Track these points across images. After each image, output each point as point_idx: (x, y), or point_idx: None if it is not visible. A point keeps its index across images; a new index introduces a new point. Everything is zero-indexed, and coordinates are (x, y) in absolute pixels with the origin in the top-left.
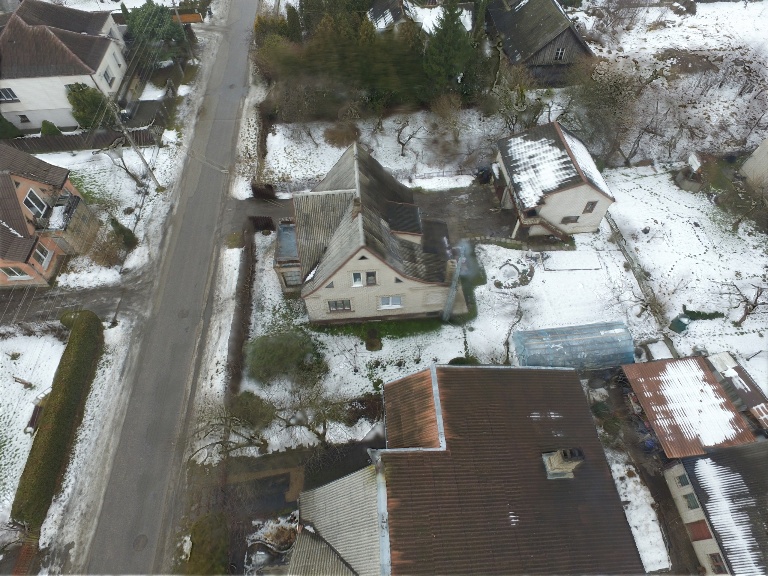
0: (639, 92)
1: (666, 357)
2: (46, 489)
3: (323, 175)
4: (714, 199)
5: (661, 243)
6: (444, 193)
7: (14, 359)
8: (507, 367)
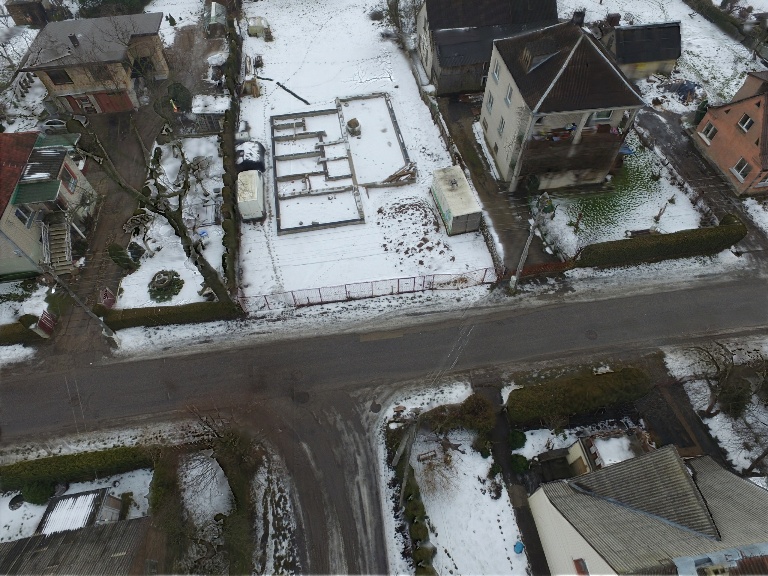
0: None
1: None
2: (605, 260)
3: None
4: None
5: None
6: None
7: (669, 202)
8: None
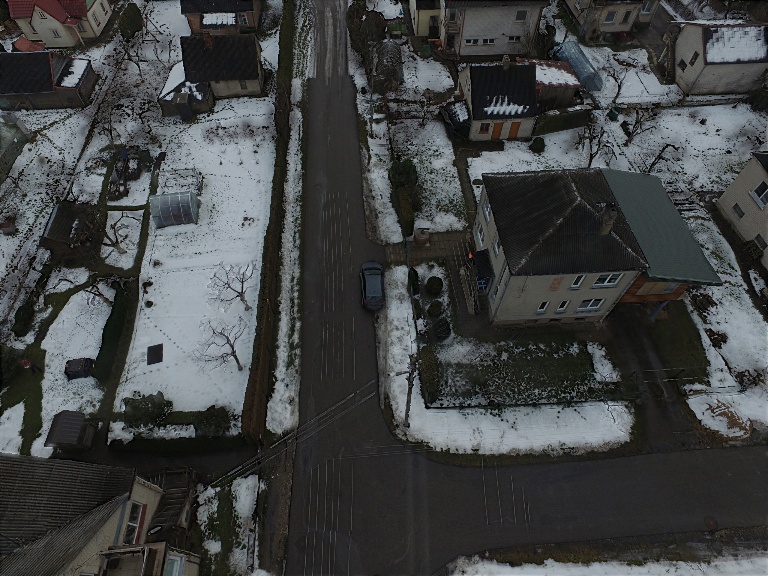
0: None
1: None
2: None
3: None
4: None
5: (691, 121)
6: None
7: None
8: None
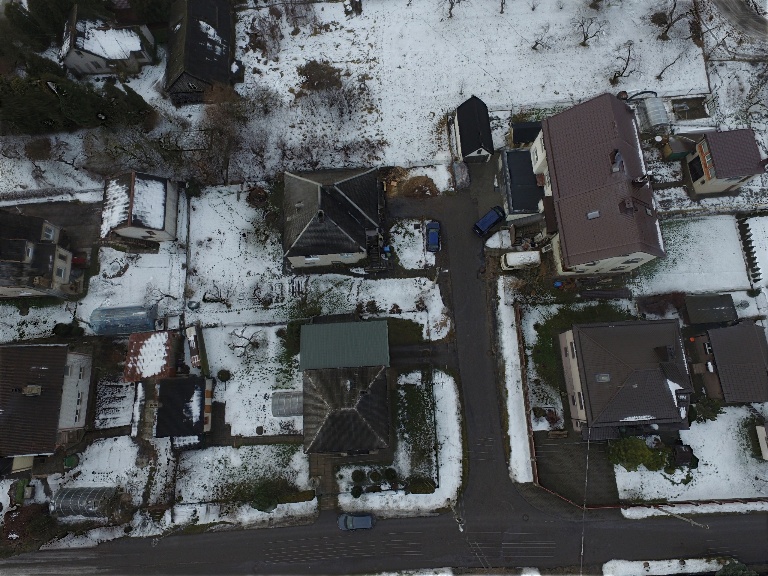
0: (266, 111)
1: (176, 325)
2: None
3: (19, 186)
4: (266, 215)
5: (210, 250)
6: (93, 205)
7: None
8: (27, 346)
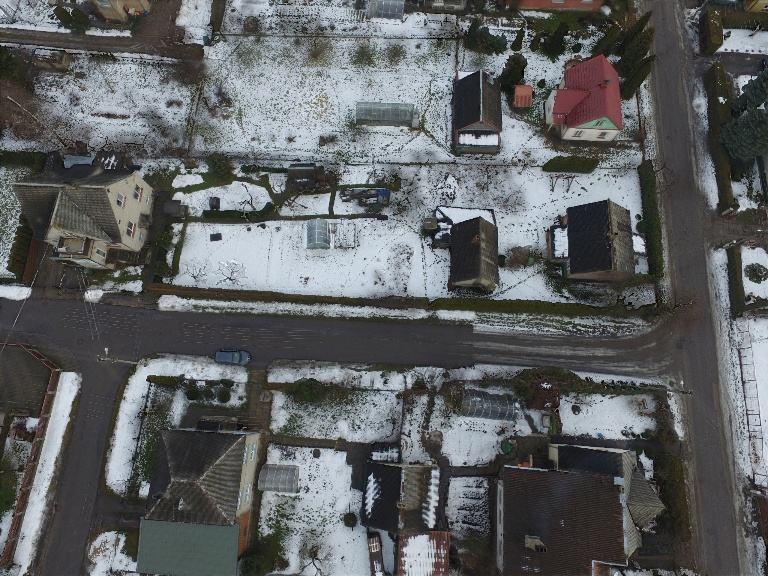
0: None
1: None
2: None
3: None
4: None
5: None
6: None
7: None
8: None
